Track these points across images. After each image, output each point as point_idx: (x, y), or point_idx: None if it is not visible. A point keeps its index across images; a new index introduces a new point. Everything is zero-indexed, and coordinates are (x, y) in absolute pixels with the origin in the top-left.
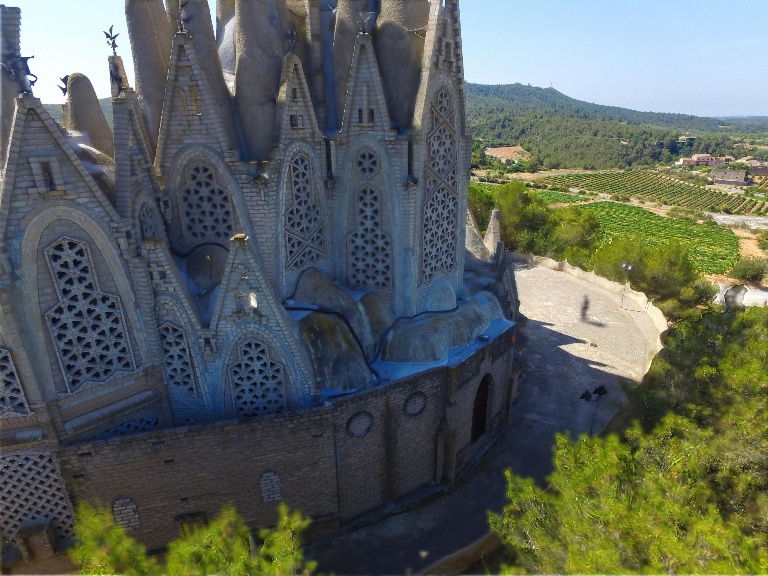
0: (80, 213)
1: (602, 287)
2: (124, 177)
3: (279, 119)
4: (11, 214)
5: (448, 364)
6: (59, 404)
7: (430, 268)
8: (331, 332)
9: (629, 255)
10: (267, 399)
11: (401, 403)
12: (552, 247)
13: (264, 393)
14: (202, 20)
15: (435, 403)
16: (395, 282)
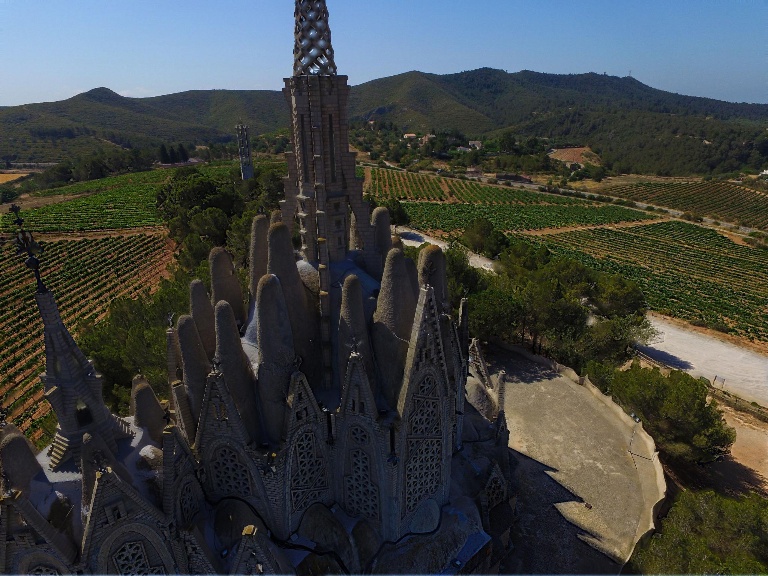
0: (137, 524)
1: (617, 416)
2: (169, 486)
3: (287, 420)
4: (92, 541)
5: None
6: None
7: (414, 499)
8: (323, 574)
9: (645, 391)
10: None
11: None
12: (579, 348)
13: None
14: (232, 343)
15: None
16: (382, 516)
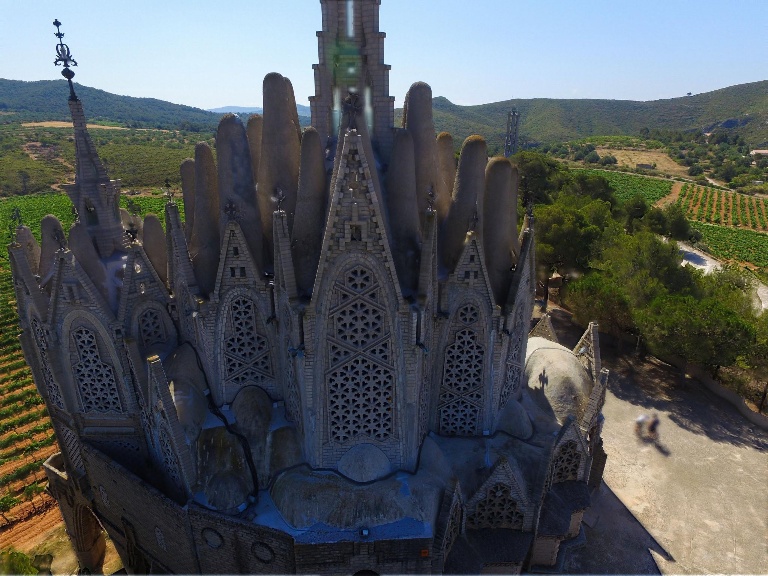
0: (91, 315)
1: None
2: (123, 295)
3: None
4: (57, 310)
5: (297, 537)
6: (82, 416)
7: (346, 431)
8: (222, 450)
9: None
10: (177, 475)
11: (249, 543)
12: None
13: (175, 470)
14: (203, 185)
15: (285, 563)
16: (304, 430)
